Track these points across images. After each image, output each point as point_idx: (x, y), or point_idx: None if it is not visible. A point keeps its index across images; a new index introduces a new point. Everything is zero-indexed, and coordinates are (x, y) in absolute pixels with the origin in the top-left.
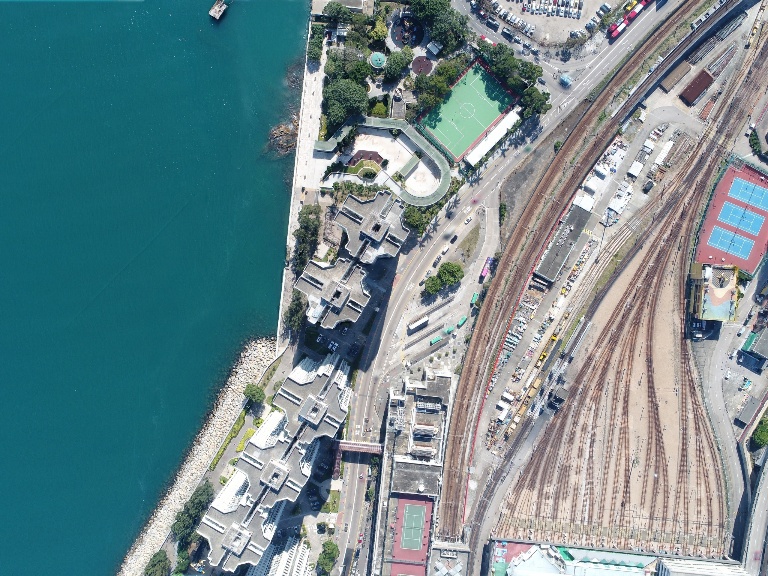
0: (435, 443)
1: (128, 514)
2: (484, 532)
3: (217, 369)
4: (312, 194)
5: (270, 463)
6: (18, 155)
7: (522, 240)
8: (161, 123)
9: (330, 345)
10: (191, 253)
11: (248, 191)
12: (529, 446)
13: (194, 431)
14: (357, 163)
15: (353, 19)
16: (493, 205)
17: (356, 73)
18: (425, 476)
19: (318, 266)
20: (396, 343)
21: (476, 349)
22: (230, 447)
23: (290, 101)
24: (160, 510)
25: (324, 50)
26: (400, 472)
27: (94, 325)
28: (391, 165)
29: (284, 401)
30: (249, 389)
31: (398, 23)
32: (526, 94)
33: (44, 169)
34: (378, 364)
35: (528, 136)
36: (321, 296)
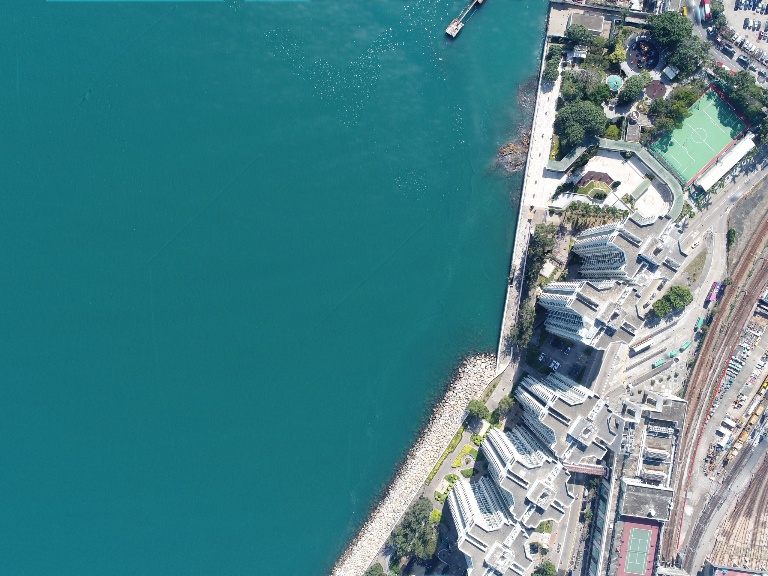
0: (664, 467)
1: (337, 525)
2: (698, 559)
3: (433, 383)
4: (540, 213)
5: (539, 483)
6: (267, 165)
7: (749, 266)
8: (408, 138)
9: (552, 364)
10: (431, 268)
11: (473, 207)
12: (747, 473)
13: (407, 445)
14: (587, 184)
15: (594, 42)
16: (721, 230)
17: (597, 95)
18: (656, 500)
19: (594, 287)
20: (617, 365)
21: (698, 374)
22: (446, 462)
23: (520, 120)
24: (371, 523)
25: (559, 71)
26: (631, 495)
27: (332, 336)
28: (621, 187)
29: (553, 421)
30: (476, 405)
31: (634, 47)
32: (767, 122)
33: (290, 179)
34: (598, 385)
35: (759, 163)
36: (598, 318)
